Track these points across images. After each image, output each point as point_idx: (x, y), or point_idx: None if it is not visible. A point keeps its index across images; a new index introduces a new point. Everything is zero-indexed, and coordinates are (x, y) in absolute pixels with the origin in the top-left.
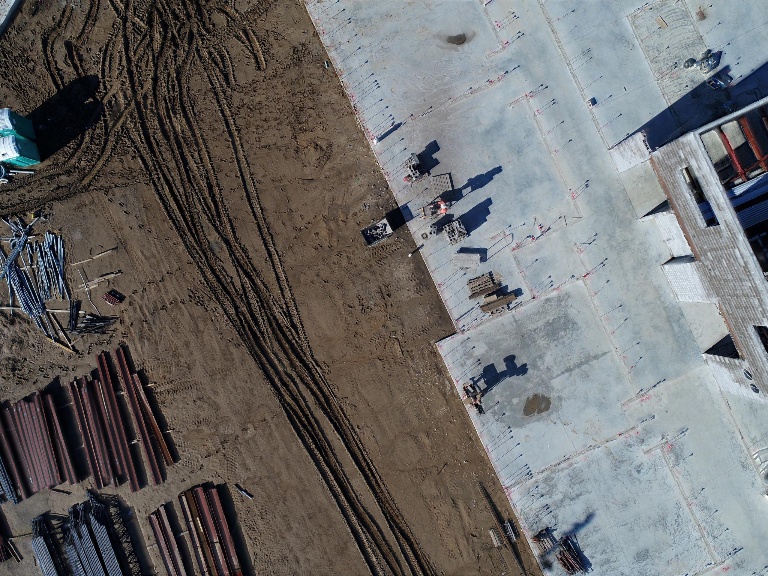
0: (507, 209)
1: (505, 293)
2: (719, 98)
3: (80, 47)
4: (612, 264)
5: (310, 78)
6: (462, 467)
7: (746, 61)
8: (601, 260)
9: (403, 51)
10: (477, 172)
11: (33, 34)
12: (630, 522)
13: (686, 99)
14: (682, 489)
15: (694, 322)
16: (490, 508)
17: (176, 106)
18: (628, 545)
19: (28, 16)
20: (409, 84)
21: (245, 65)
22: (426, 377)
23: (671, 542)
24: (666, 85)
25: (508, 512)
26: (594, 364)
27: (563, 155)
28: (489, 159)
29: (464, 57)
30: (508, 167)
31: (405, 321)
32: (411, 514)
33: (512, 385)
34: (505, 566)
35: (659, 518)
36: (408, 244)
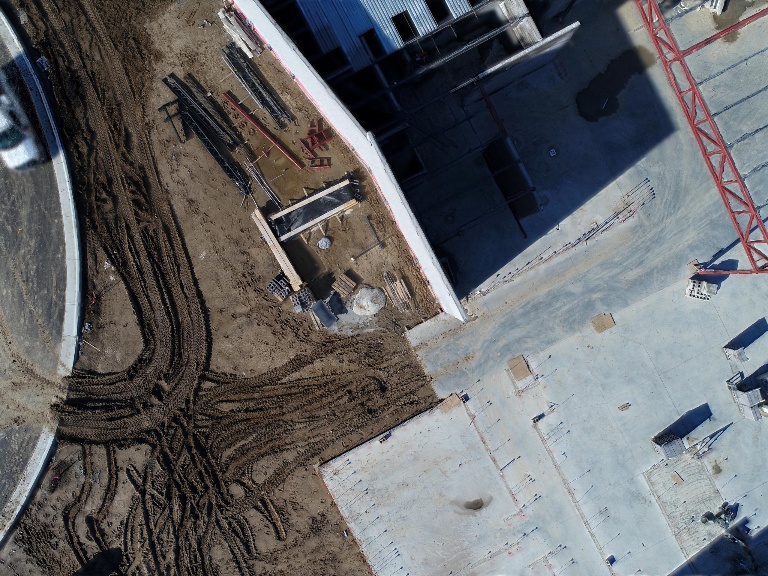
0: None
1: None
2: (737, 550)
3: (101, 522)
4: None
5: (330, 546)
6: None
7: (763, 512)
8: None
9: (421, 519)
10: None
11: (54, 510)
12: None
13: (704, 552)
14: None
15: None
16: None
17: (199, 575)
18: None
19: (48, 493)
20: (428, 551)
21: (265, 534)
22: None
23: None
24: (684, 539)
25: None
26: None
27: None
28: None
29: (482, 522)
30: None
31: None
32: None
33: None
34: None
35: None
36: None
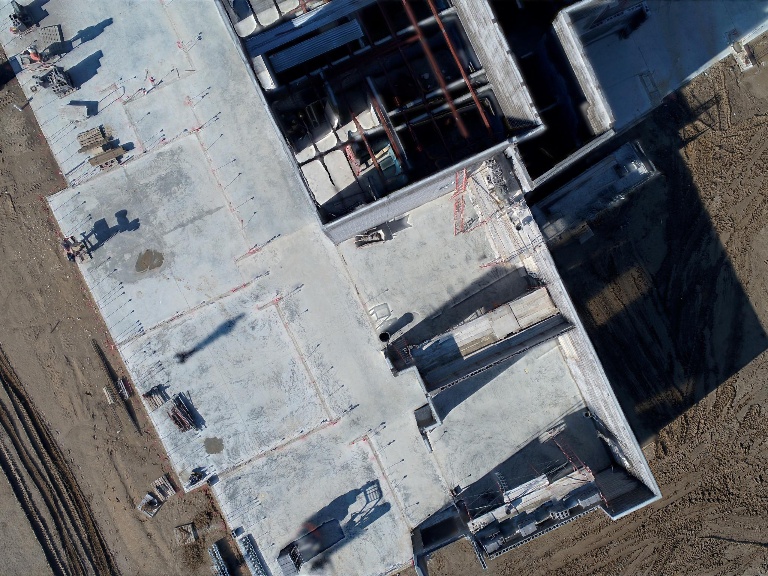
0: (118, 62)
1: (115, 147)
2: None
3: None
4: (226, 118)
5: None
6: (76, 324)
7: None
8: (214, 114)
9: None
10: (87, 24)
11: None
12: (244, 379)
13: None
14: (297, 345)
15: (309, 176)
16: (103, 365)
17: None
18: (242, 402)
19: None
20: None
21: None
22: (38, 233)
23: (286, 399)
24: None
25: (122, 369)
26: (207, 219)
27: (175, 7)
28: (100, 11)
29: None
30: (119, 19)
31: (17, 176)
32: (25, 372)
33: (124, 240)
34: (120, 424)
35: (274, 374)
36: (19, 98)
